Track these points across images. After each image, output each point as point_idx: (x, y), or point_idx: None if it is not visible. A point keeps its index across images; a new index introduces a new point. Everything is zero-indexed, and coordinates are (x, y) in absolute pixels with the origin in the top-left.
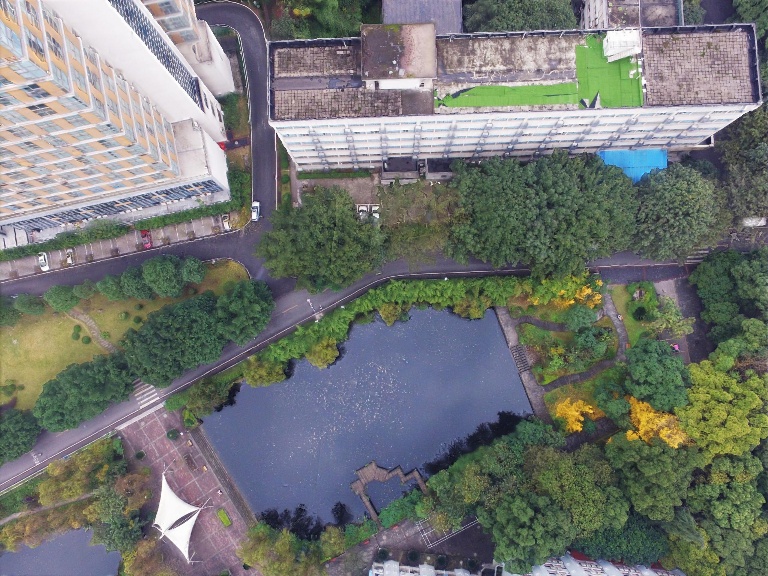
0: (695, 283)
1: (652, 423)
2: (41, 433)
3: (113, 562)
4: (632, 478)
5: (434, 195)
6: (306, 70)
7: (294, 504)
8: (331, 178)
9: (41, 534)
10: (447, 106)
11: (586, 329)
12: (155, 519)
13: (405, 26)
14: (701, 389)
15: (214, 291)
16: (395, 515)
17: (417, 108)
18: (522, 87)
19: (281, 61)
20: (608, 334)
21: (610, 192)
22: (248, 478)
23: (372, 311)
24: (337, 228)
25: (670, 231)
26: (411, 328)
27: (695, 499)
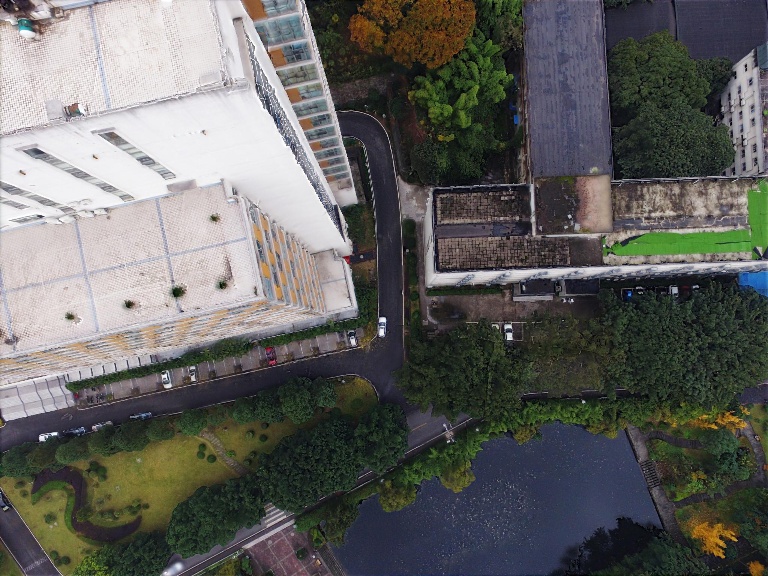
0: None
1: None
2: (171, 556)
3: None
4: None
5: (591, 335)
6: (470, 217)
7: None
8: (461, 295)
9: None
10: (616, 254)
11: (727, 454)
12: None
13: (580, 178)
14: None
15: (341, 409)
16: None
17: (585, 257)
18: (693, 234)
19: (444, 207)
20: (748, 457)
21: None
22: None
23: None
24: (490, 367)
25: None
26: (539, 443)
27: None
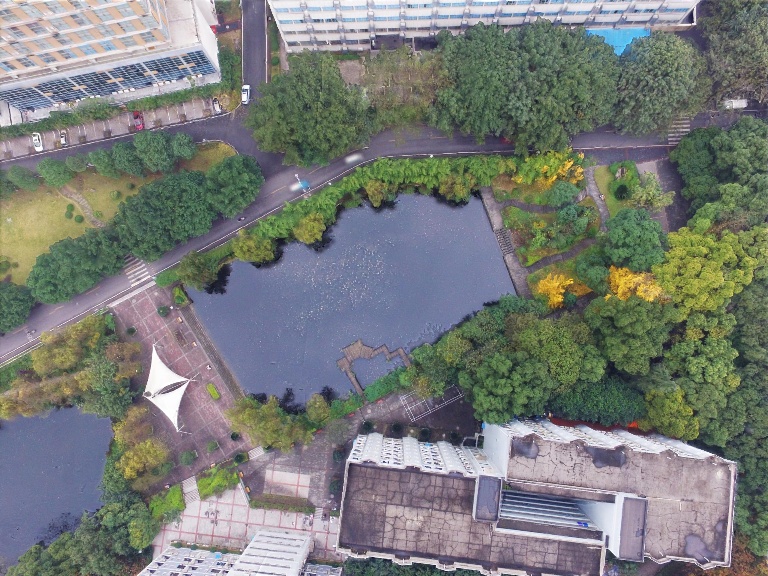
0: (676, 160)
1: (629, 282)
2: (34, 306)
3: (105, 439)
4: (609, 335)
5: (419, 58)
6: None
7: (282, 389)
8: None
9: (34, 400)
10: None
11: (568, 205)
12: (145, 389)
13: None
14: (677, 248)
15: (205, 172)
16: (380, 390)
17: None
18: None
19: None
20: (590, 211)
21: (592, 59)
22: (237, 355)
23: (359, 192)
24: (323, 91)
25: (650, 95)
26: (398, 212)
27: (671, 360)
